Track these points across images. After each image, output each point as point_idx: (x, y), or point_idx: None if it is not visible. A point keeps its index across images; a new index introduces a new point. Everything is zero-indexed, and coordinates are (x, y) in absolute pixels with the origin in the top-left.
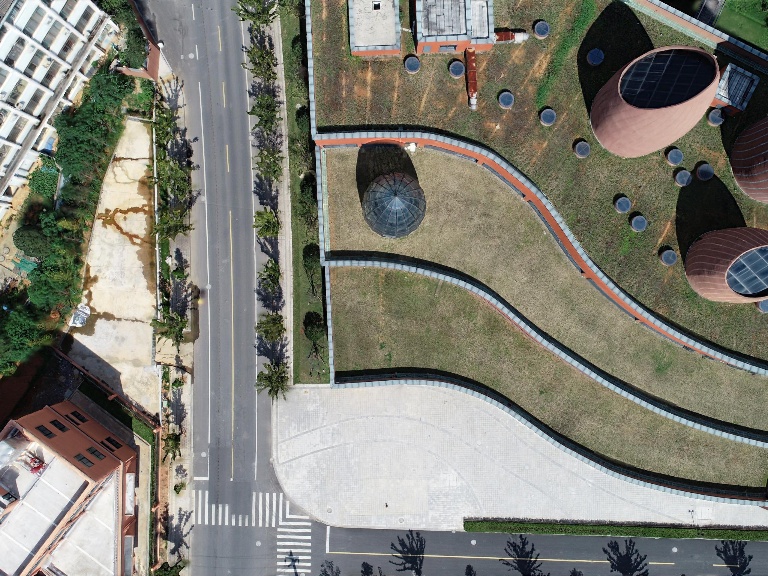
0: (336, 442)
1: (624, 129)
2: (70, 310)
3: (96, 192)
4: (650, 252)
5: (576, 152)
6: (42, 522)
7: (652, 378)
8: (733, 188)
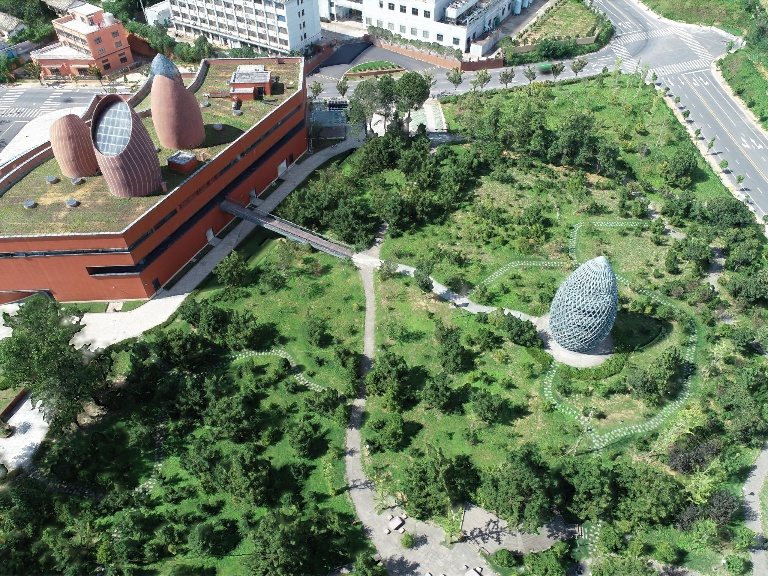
0: None
1: None
2: (174, 62)
3: None
4: None
5: None
6: None
7: None
8: None
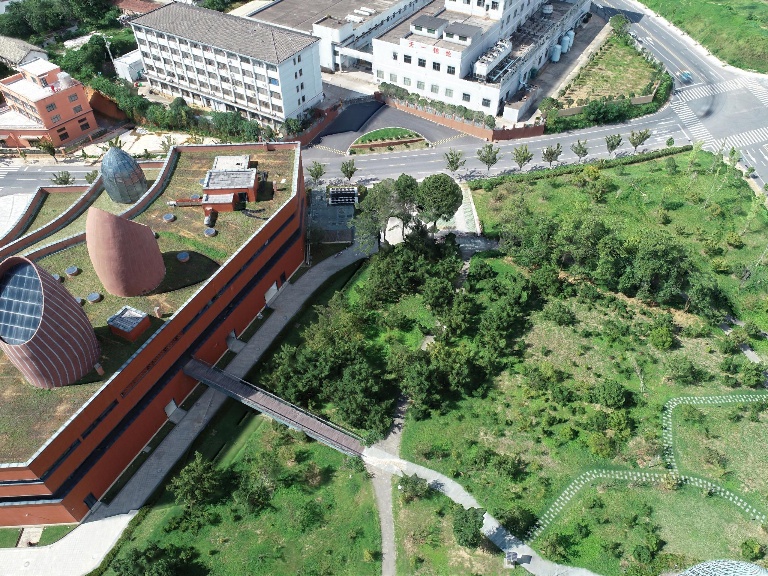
0: (12, 218)
1: None
2: (146, 128)
3: (206, 134)
4: None
5: None
6: (27, 93)
7: None
8: None
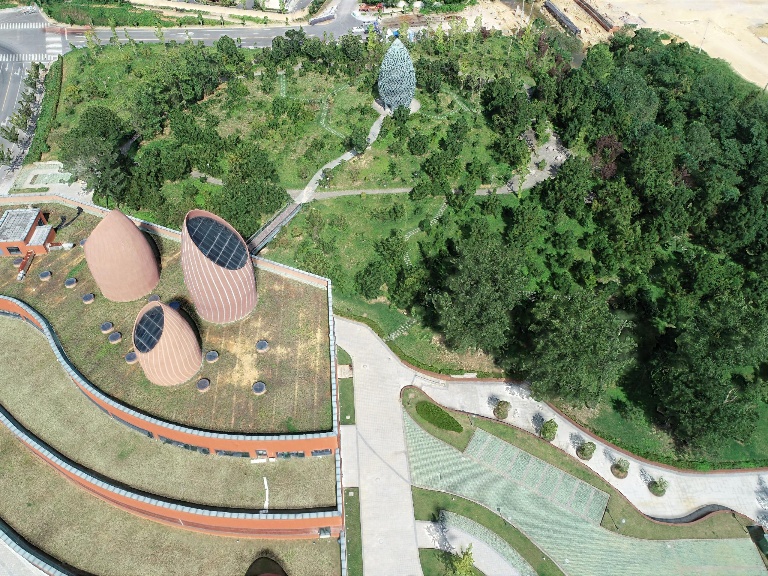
0: None
1: (90, 267)
2: None
3: None
4: (120, 356)
5: (82, 299)
6: None
7: (113, 463)
8: (195, 316)
